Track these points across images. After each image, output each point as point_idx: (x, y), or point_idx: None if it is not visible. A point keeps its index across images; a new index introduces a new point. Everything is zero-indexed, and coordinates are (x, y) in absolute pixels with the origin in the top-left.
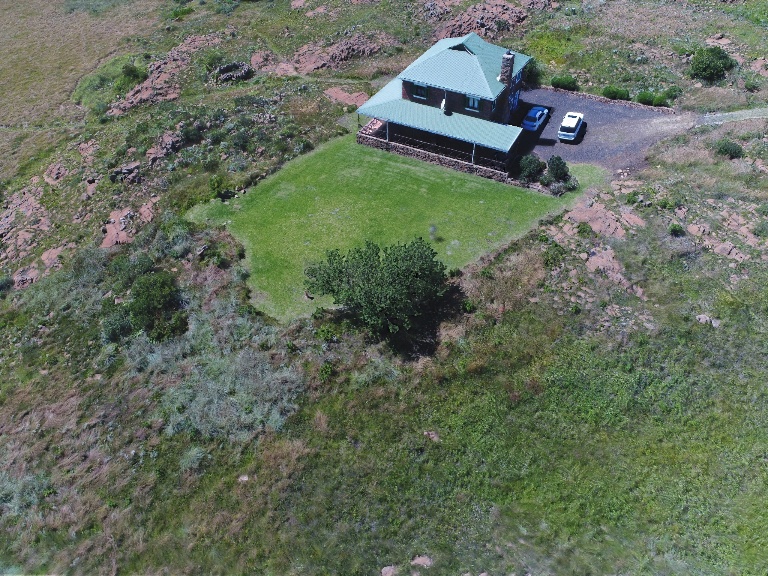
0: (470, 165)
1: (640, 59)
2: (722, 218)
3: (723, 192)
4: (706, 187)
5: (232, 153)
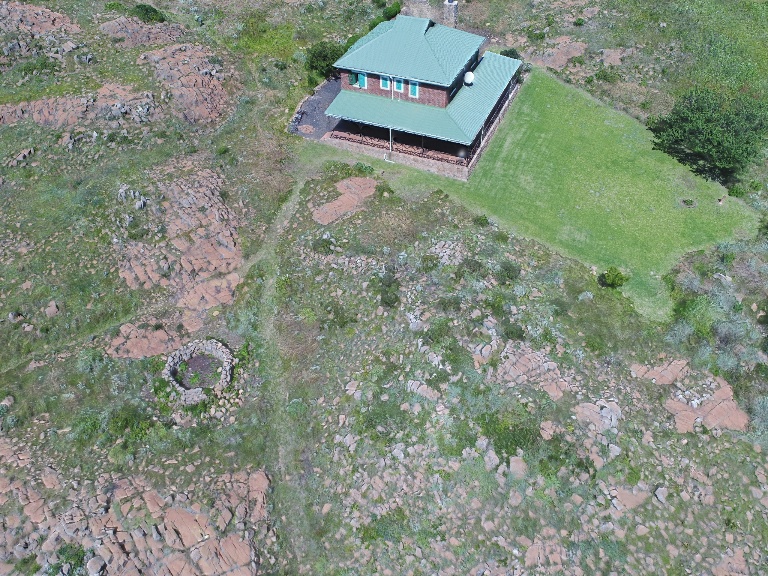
0: None
1: (323, 3)
2: (560, 7)
3: (528, 3)
4: (521, 8)
5: (528, 285)
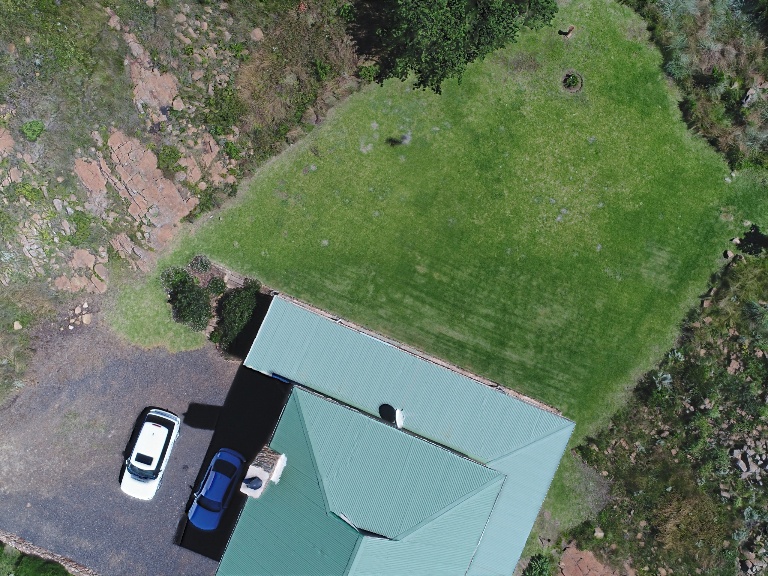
0: (344, 320)
1: None
2: None
3: None
4: None
5: None
